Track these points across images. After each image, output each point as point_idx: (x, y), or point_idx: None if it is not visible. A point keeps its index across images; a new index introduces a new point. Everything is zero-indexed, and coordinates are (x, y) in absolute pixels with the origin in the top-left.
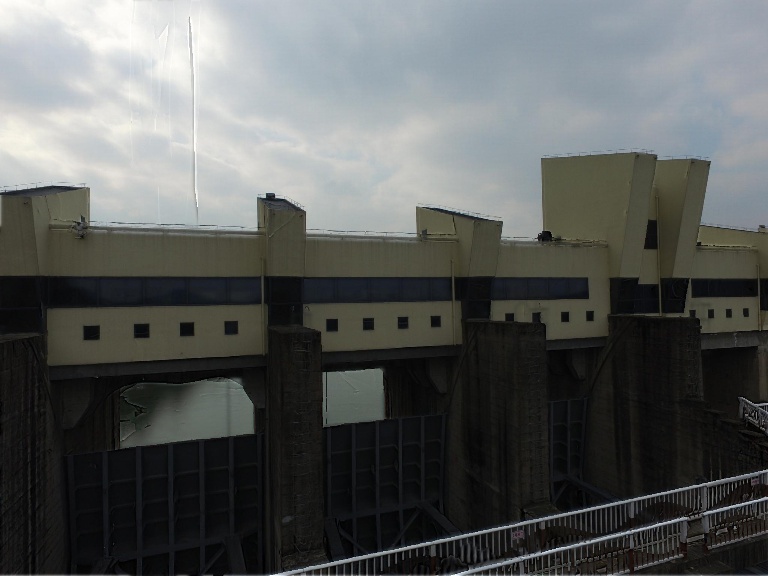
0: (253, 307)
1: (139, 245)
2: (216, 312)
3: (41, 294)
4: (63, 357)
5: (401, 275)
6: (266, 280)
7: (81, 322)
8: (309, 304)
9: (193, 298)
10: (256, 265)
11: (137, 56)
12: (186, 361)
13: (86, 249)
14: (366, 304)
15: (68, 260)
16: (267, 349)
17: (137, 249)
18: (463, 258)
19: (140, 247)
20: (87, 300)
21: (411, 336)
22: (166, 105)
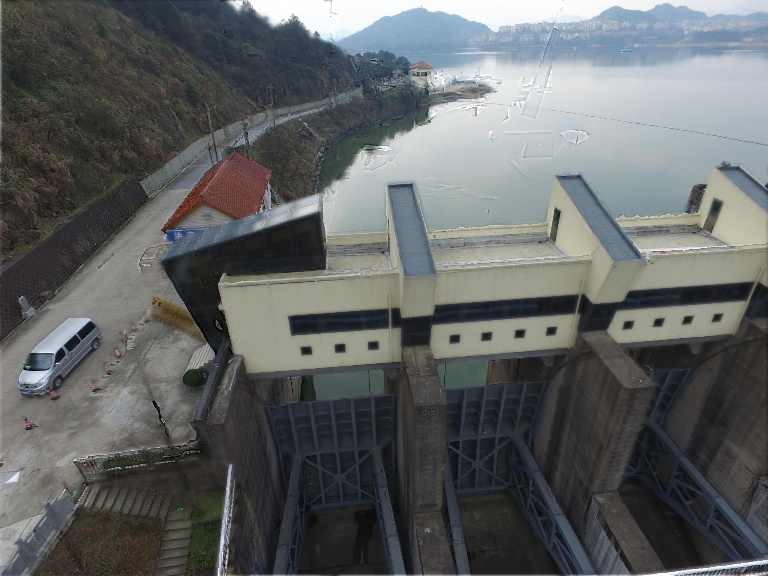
0: (738, 303)
1: (676, 266)
2: (711, 308)
3: None
4: None
5: None
6: (758, 285)
7: (624, 319)
8: None
9: (698, 299)
10: (754, 273)
11: None
12: (678, 339)
13: None
14: None
15: None
16: (736, 331)
17: (673, 269)
18: None
19: (676, 268)
20: (630, 305)
21: None
22: None
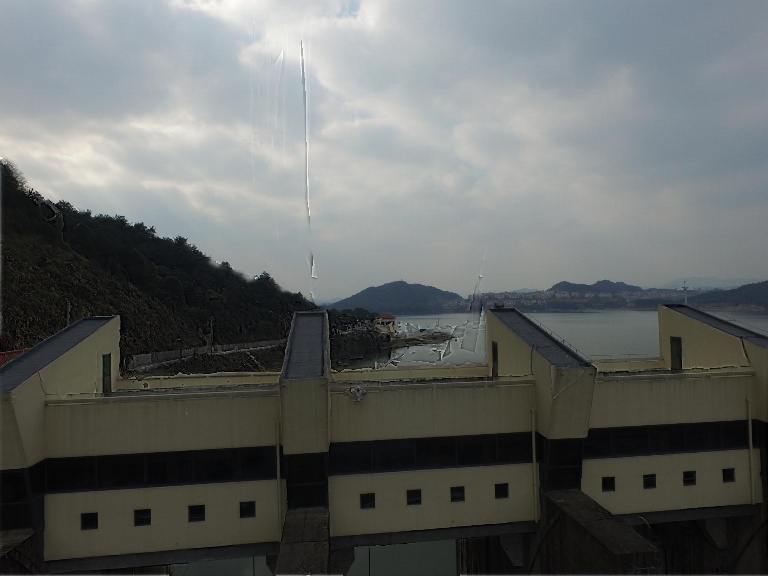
0: (523, 466)
1: (409, 404)
2: (486, 474)
3: (328, 469)
4: (342, 527)
5: (686, 420)
6: (537, 436)
7: (358, 490)
8: (583, 460)
9: (462, 458)
10: (525, 418)
11: (256, 82)
12: (456, 528)
13: (361, 412)
14: (646, 457)
15: (345, 425)
16: (539, 514)
17: (408, 409)
18: (766, 399)
19: (410, 406)
20: (362, 465)
21: (699, 494)
22: (281, 125)
